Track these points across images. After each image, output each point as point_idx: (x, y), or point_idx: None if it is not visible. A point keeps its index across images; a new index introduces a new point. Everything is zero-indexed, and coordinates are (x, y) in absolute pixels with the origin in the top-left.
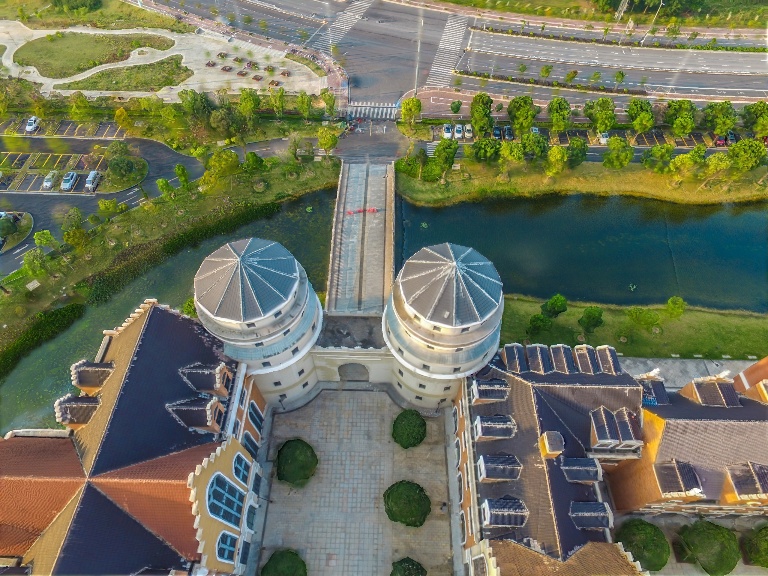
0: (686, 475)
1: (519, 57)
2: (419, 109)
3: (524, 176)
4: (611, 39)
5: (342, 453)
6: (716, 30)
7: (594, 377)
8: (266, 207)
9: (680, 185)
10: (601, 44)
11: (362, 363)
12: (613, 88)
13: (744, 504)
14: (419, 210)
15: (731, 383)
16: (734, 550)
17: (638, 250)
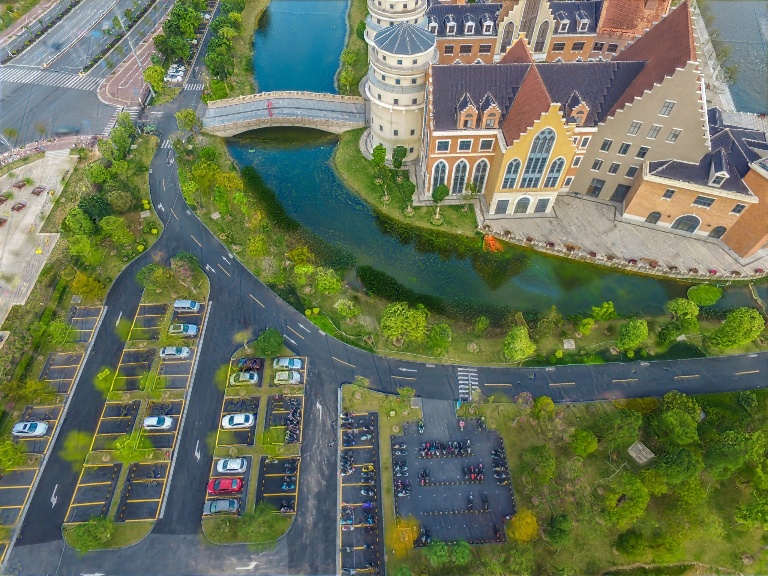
0: None
1: (75, 42)
2: None
3: None
4: None
5: None
6: None
7: None
8: (247, 173)
9: (256, 0)
10: (76, 7)
11: None
12: (144, 8)
13: None
14: None
15: None
16: None
17: (305, 23)
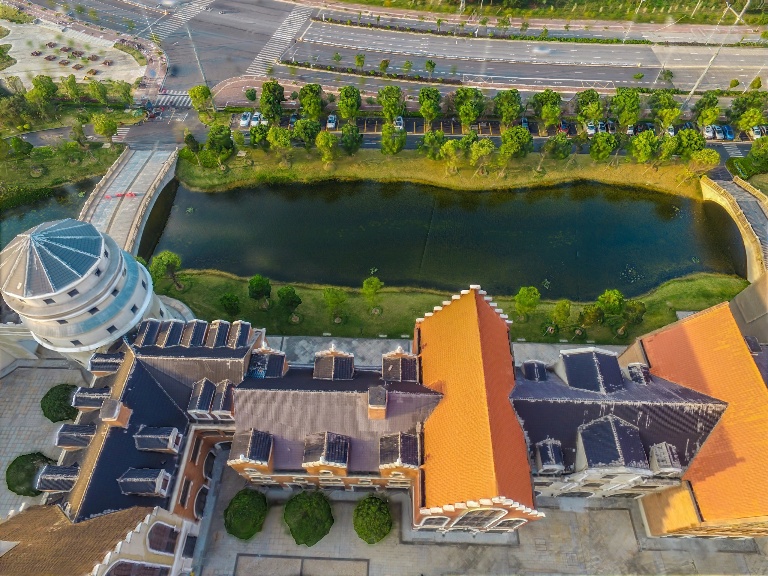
0: (259, 444)
1: (348, 47)
2: (205, 96)
3: (306, 163)
4: (449, 30)
5: (12, 428)
6: (558, 21)
7: (207, 350)
8: (37, 192)
9: (458, 172)
10: (436, 35)
11: (34, 340)
12: None
13: (326, 473)
14: (191, 195)
15: (351, 357)
16: (318, 518)
17: (395, 235)
